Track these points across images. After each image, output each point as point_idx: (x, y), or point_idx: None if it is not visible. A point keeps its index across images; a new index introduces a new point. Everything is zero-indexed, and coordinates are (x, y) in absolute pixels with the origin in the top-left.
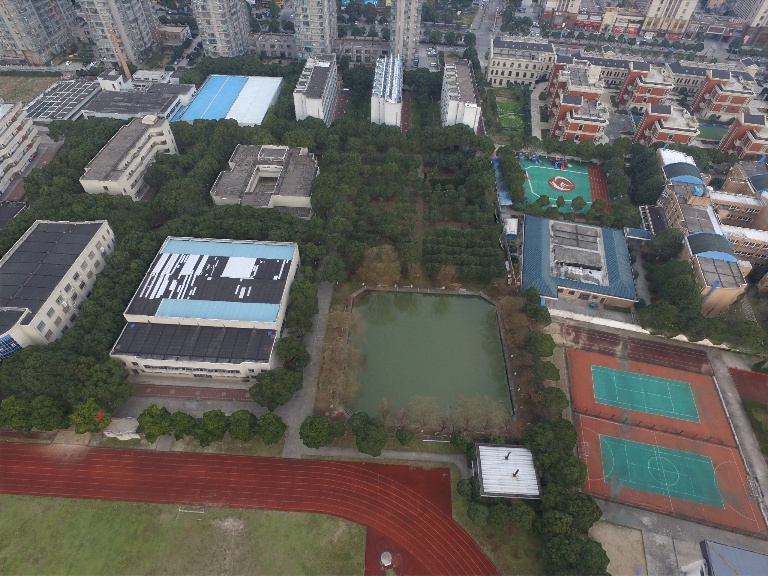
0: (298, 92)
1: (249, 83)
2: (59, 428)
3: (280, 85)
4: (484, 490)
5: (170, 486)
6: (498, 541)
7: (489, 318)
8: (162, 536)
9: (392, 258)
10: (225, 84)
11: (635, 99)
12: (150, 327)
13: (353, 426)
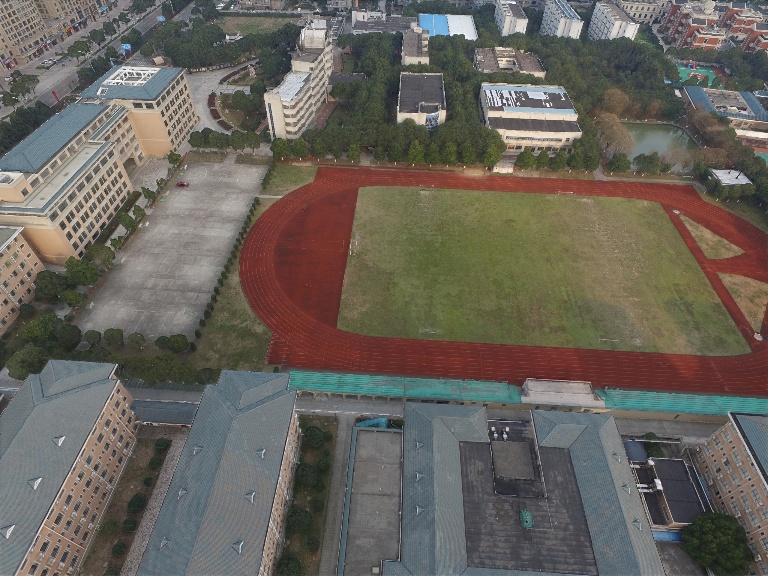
0: (508, 16)
1: (450, 19)
2: (475, 161)
3: (474, 19)
4: (723, 183)
5: (543, 188)
6: (732, 207)
7: (674, 141)
8: (553, 203)
9: (624, 94)
10: (434, 19)
11: (733, 30)
12: (502, 119)
13: (641, 158)
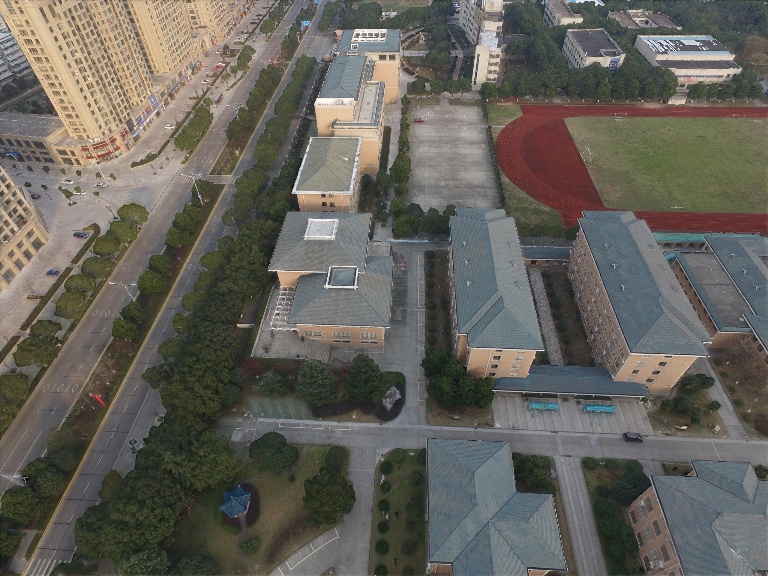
0: None
1: None
2: None
3: None
4: None
5: None
6: None
7: None
8: (730, 123)
9: (765, 39)
10: None
11: None
12: (668, 62)
13: None
